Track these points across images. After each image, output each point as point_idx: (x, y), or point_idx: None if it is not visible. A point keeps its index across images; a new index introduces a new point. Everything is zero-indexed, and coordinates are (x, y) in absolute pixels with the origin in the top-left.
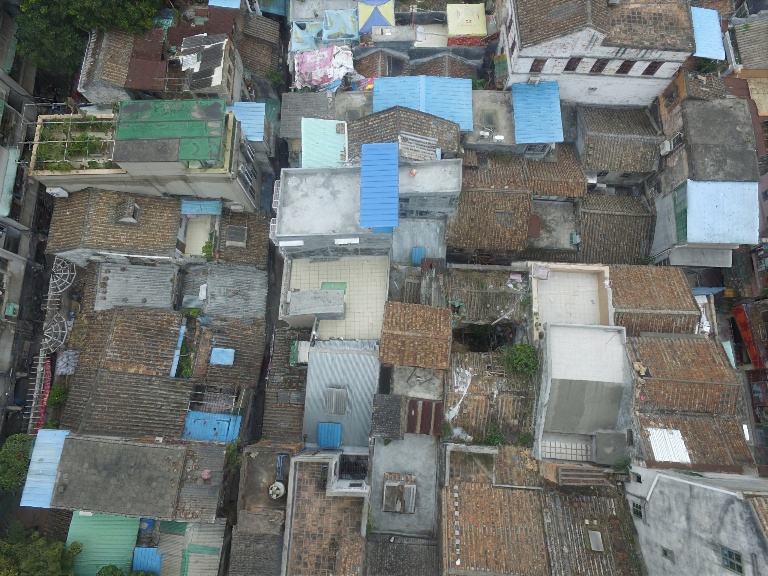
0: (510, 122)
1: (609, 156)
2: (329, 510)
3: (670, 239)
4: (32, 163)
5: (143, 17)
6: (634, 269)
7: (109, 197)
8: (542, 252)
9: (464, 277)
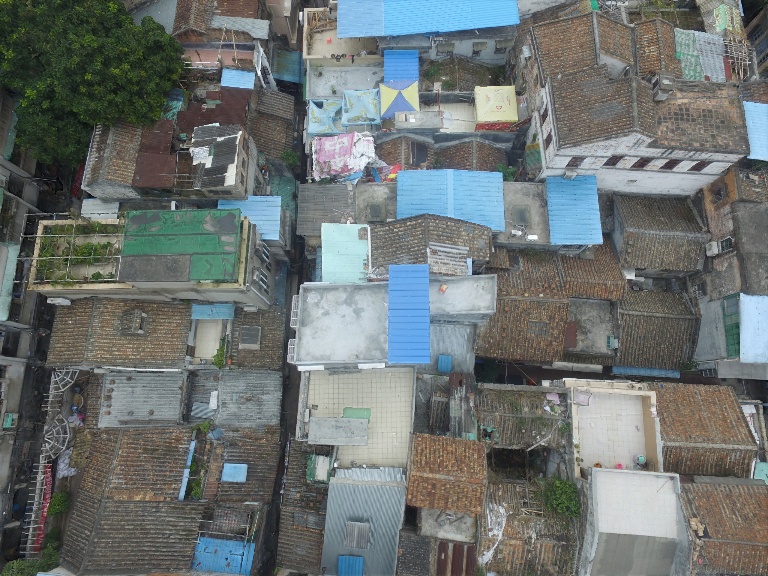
0: (544, 218)
1: (650, 254)
2: None
3: (718, 351)
4: (32, 276)
5: (151, 108)
6: (681, 389)
7: (114, 305)
8: (577, 356)
9: (496, 397)
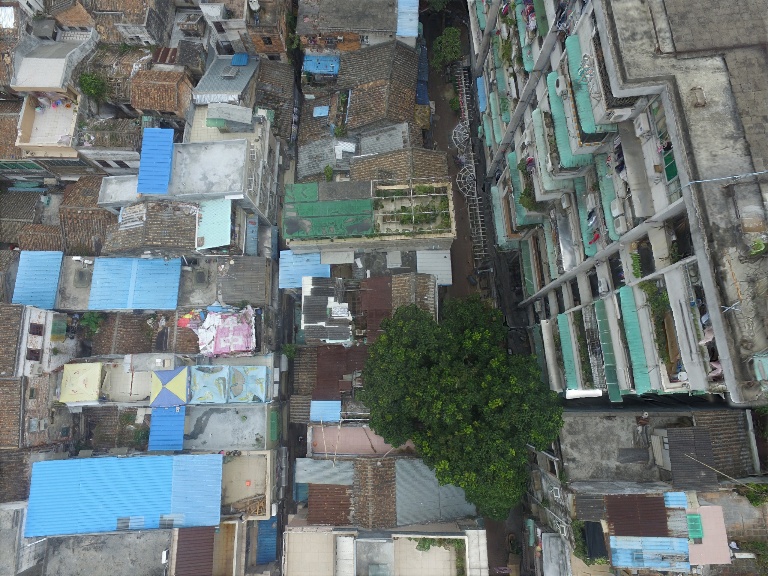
0: (66, 278)
1: None
2: (227, 3)
3: None
4: (450, 192)
5: None
6: (0, 155)
7: None
8: None
9: (126, 145)
